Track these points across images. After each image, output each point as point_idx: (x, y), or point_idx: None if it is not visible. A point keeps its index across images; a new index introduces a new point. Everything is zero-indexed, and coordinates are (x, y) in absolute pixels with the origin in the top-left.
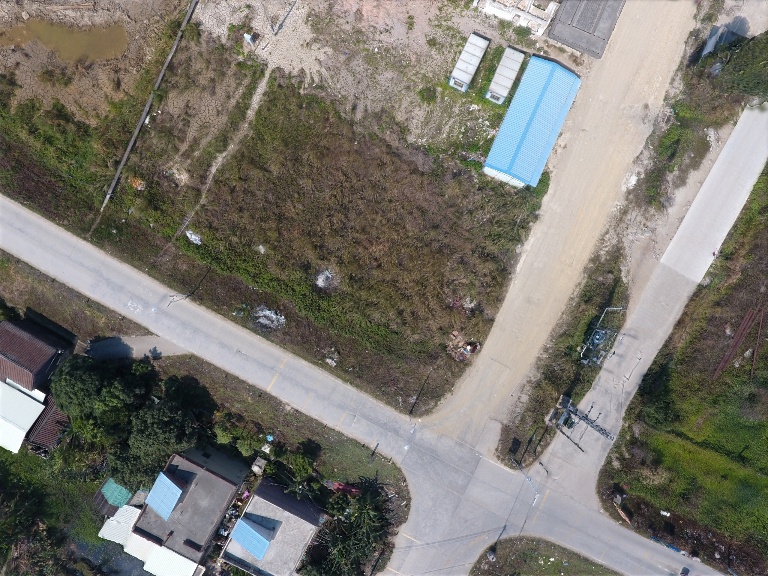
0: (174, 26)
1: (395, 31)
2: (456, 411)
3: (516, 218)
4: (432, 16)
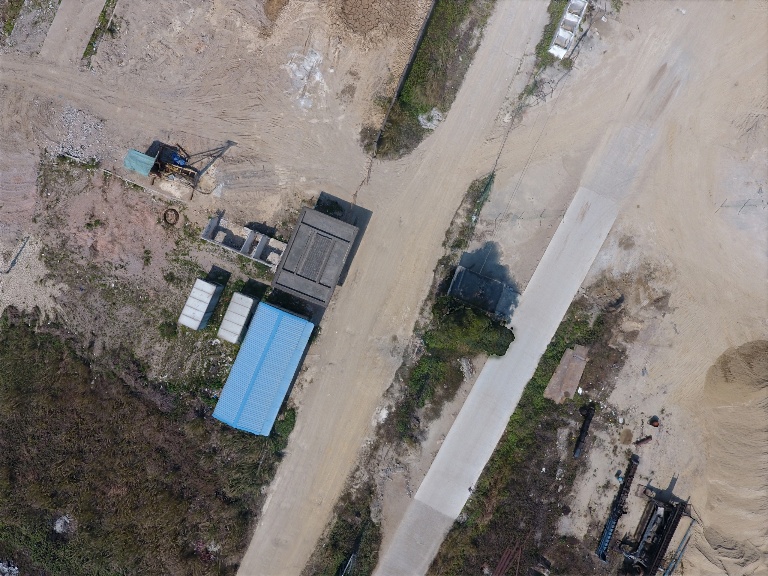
0: None
1: (130, 267)
2: None
3: (258, 460)
4: (169, 250)
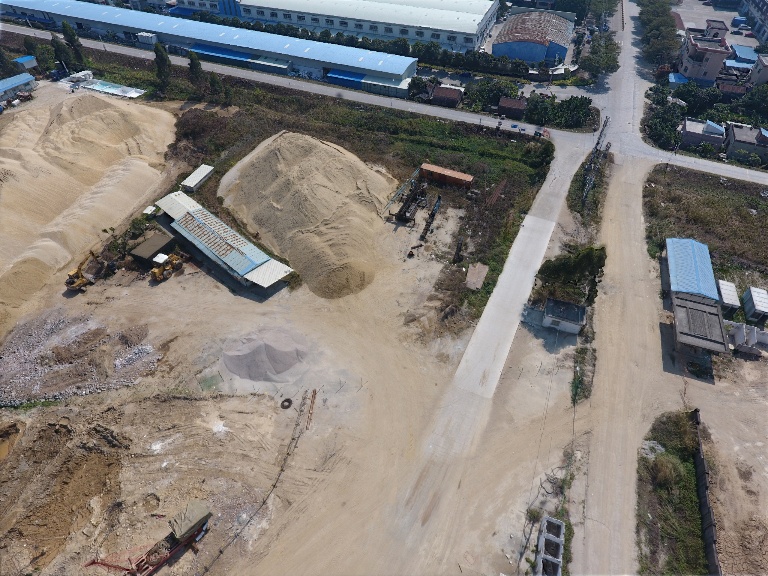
0: None
1: None
2: (642, 167)
3: None
4: None
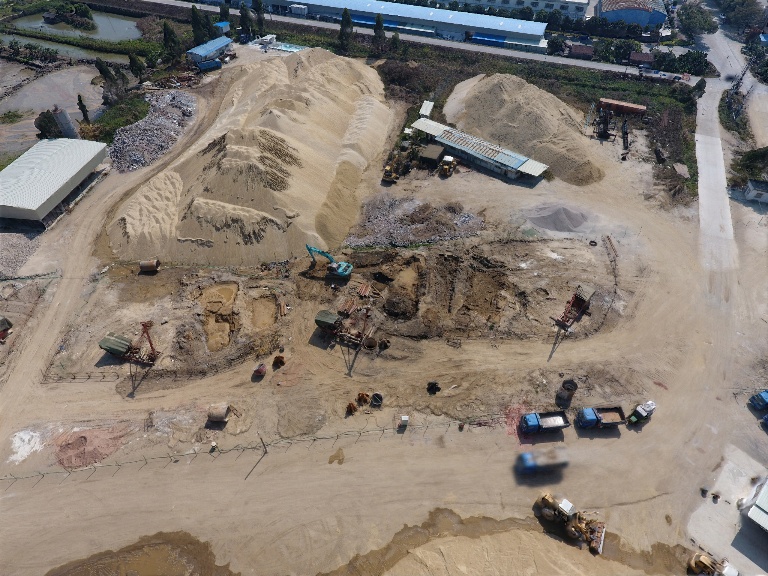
0: None
1: None
2: None
3: None
4: None
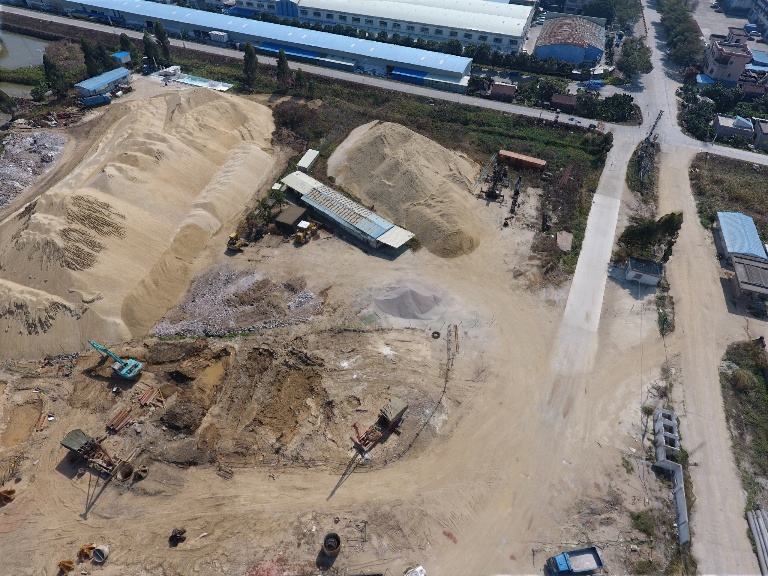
0: None
1: None
2: (685, 155)
3: None
4: None
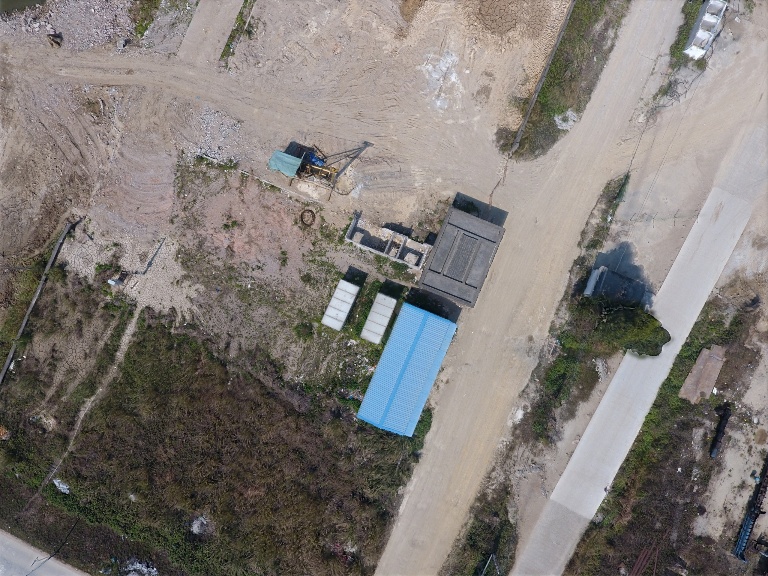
0: (38, 269)
1: (267, 268)
2: None
3: (396, 460)
4: (306, 251)
